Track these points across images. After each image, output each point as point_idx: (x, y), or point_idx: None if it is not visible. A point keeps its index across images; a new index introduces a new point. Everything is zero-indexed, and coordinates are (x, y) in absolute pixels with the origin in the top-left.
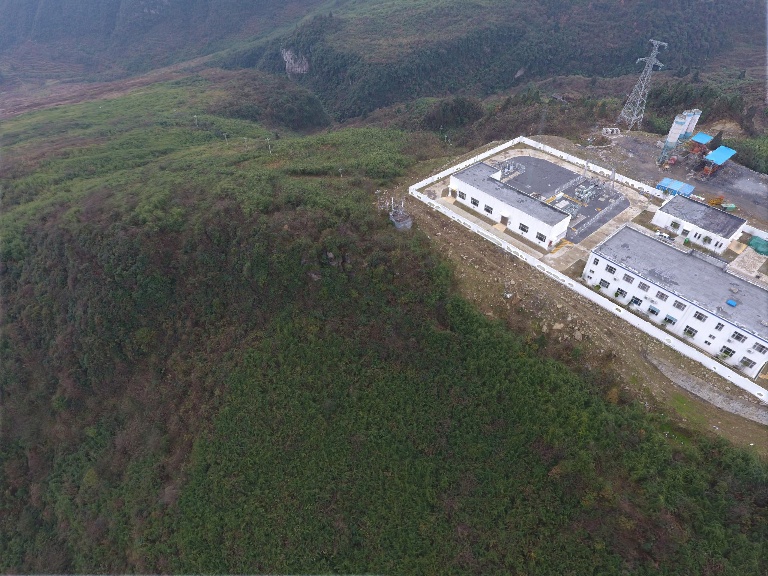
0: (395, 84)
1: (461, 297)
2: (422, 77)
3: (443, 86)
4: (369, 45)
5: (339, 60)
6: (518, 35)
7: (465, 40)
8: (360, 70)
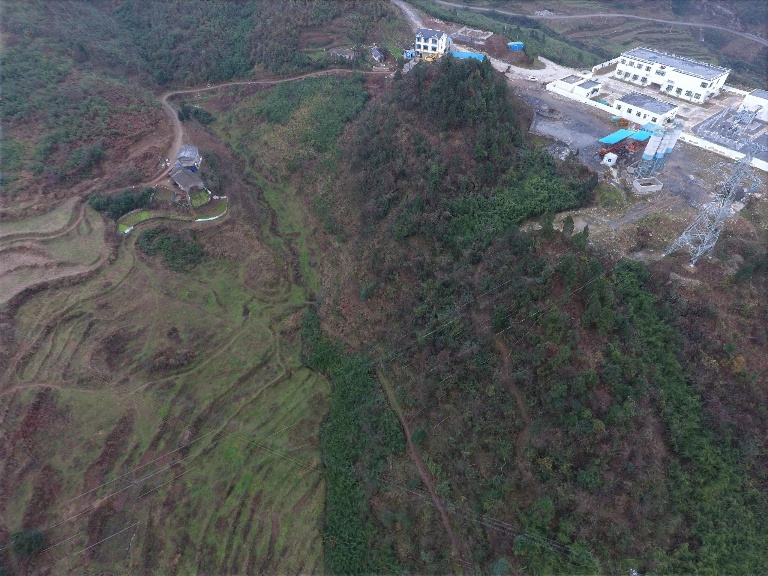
0: None
1: None
2: None
3: None
4: None
5: None
6: None
7: None
8: None
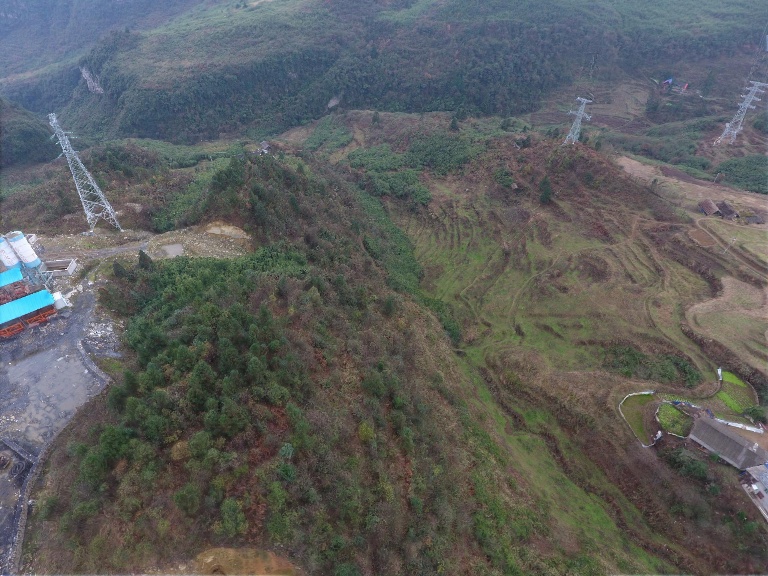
0: (169, 113)
1: None
2: (204, 105)
3: (233, 116)
4: (150, 67)
5: (120, 82)
6: (330, 60)
7: (261, 65)
8: (129, 96)
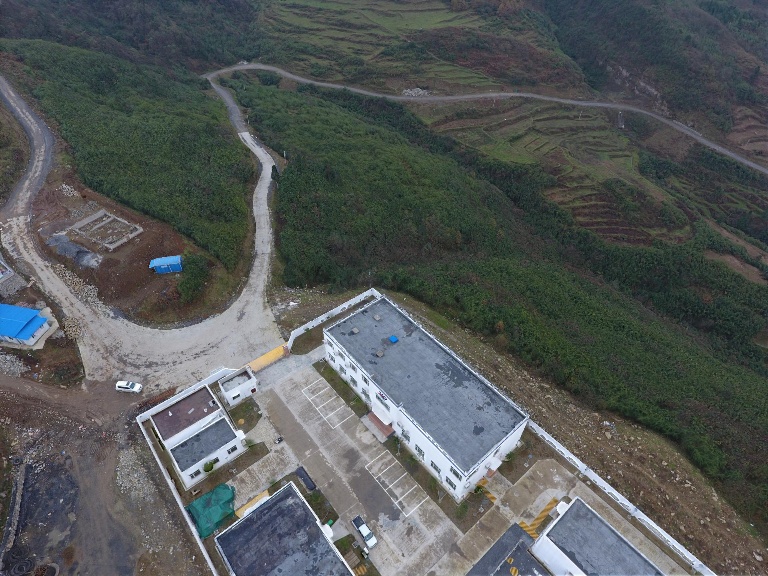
0: None
1: (665, 425)
2: None
3: None
4: None
5: None
6: None
7: None
8: None
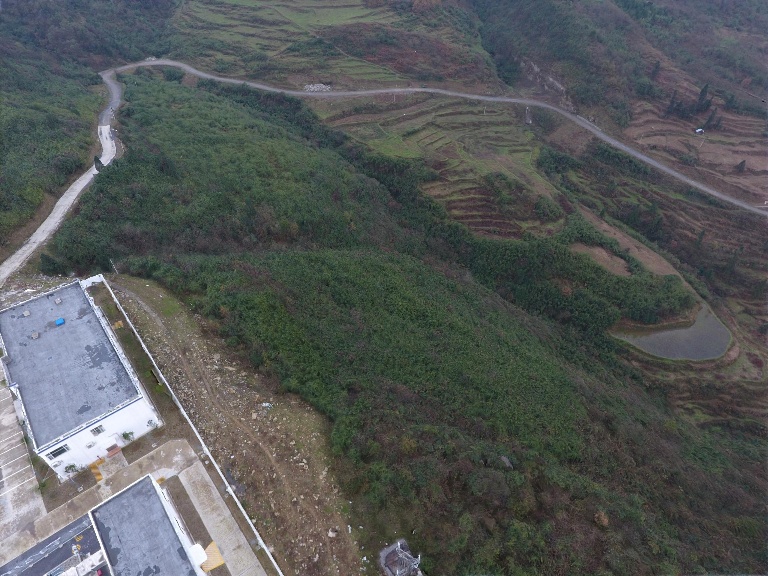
0: None
1: (326, 407)
2: None
3: None
4: None
5: None
6: None
7: None
8: None
